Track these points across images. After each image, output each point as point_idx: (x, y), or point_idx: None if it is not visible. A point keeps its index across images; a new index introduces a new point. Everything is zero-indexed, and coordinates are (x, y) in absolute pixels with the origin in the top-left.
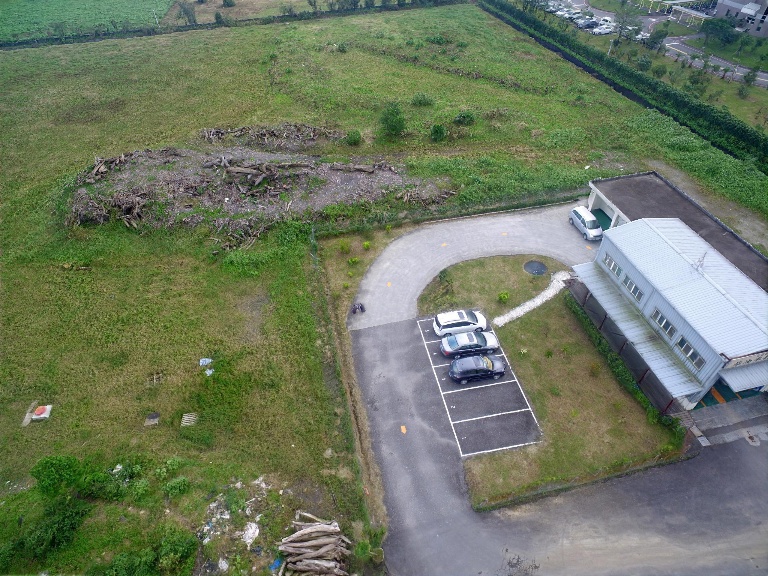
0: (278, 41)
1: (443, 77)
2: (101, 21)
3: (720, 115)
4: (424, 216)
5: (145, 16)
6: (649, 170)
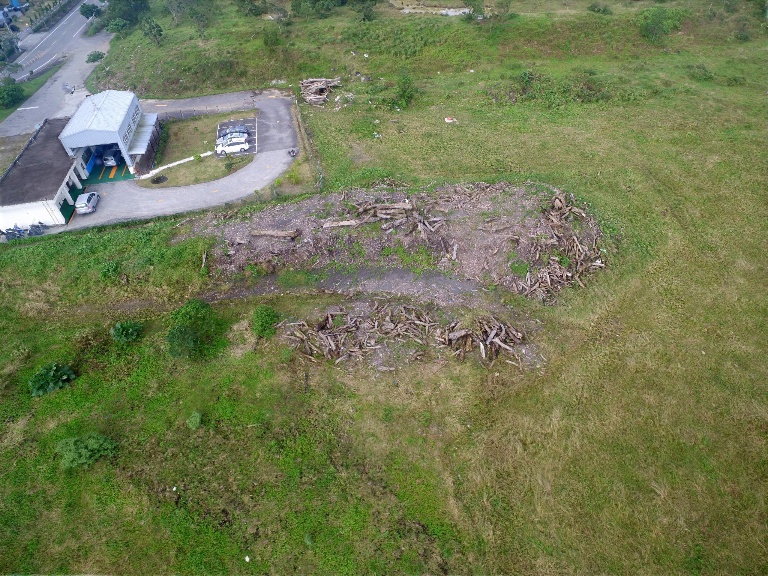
0: None
1: None
2: None
3: None
4: None
5: None
6: None
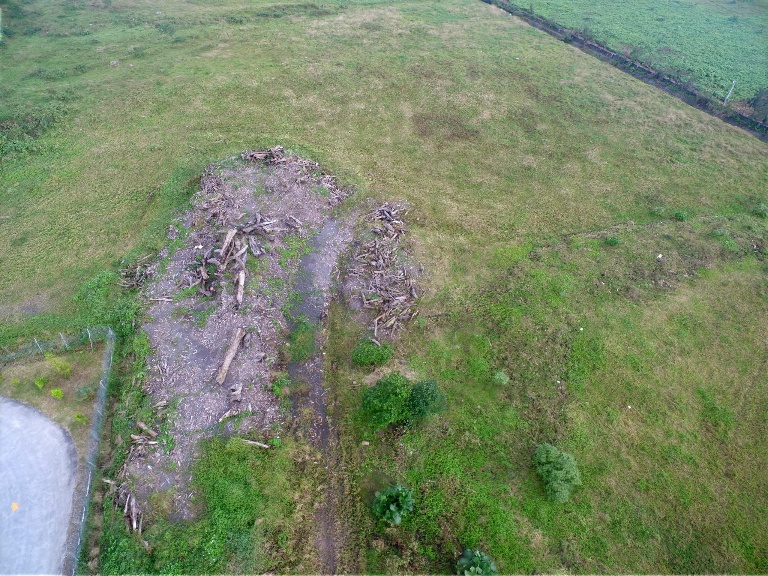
0: (757, 210)
1: (766, 536)
2: (701, 67)
3: None
4: (102, 474)
5: (753, 85)
6: None
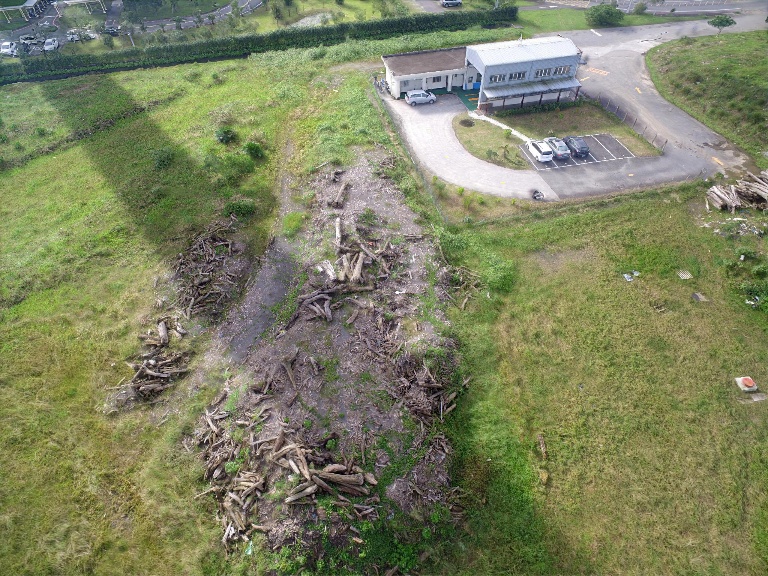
0: None
1: (85, 147)
2: None
3: (293, 31)
4: (408, 164)
5: None
6: (345, 72)
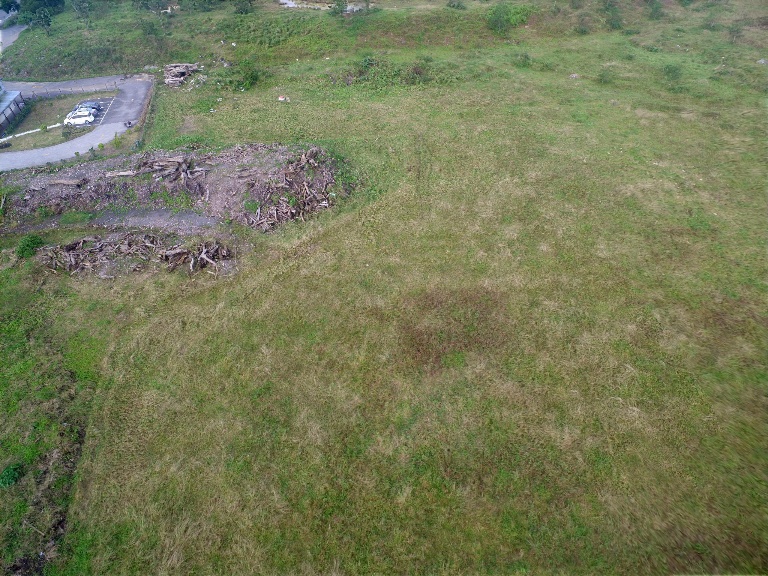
0: None
1: None
2: None
3: None
4: None
5: None
6: None
